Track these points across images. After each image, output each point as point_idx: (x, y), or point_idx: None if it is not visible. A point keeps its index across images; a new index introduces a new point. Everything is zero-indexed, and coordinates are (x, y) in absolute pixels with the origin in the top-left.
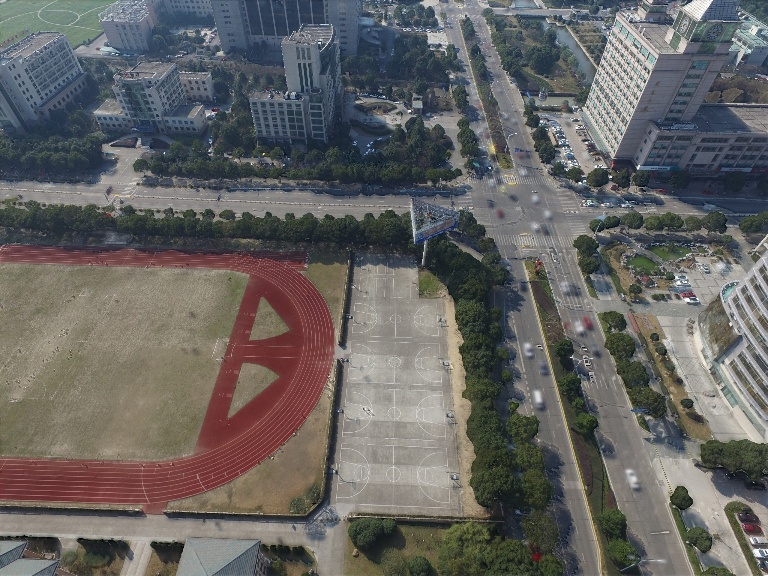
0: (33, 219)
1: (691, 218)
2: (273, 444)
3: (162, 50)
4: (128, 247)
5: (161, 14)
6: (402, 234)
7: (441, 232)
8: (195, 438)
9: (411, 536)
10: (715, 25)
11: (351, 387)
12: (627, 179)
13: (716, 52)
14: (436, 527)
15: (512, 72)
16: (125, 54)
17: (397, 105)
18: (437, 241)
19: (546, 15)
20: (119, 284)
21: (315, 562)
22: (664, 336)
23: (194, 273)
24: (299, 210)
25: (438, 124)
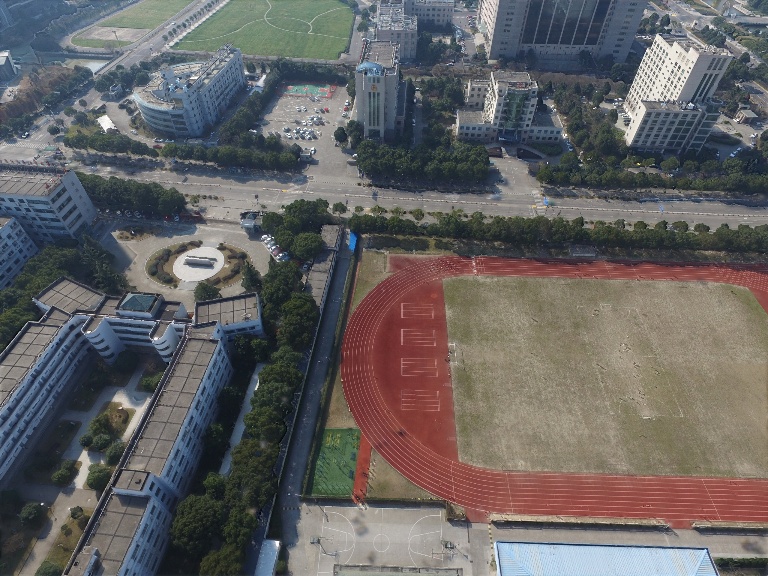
0: (507, 231)
1: None
2: None
3: (437, 58)
4: (599, 259)
5: None
6: None
7: None
8: None
9: None
10: None
11: None
12: None
13: None
14: None
15: None
16: None
17: None
18: None
19: (767, 23)
20: (629, 297)
21: None
22: None
23: (691, 286)
24: (729, 221)
25: None
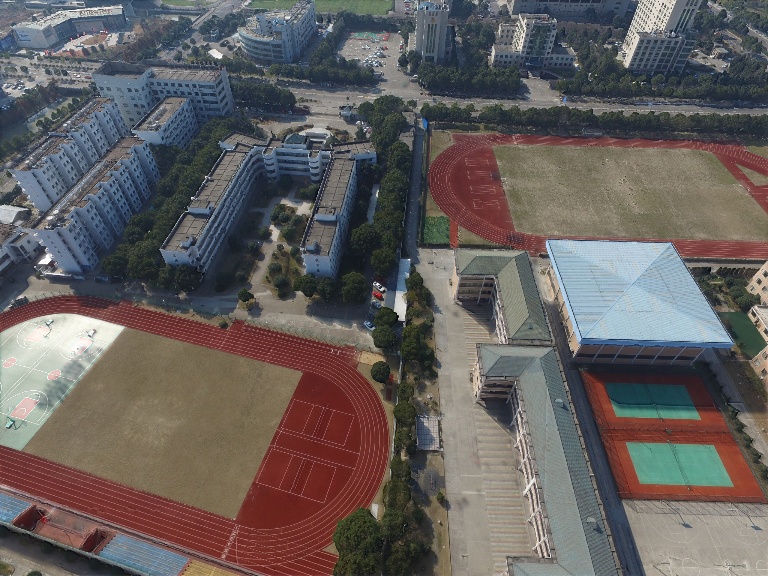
0: (538, 115)
1: None
2: None
3: None
4: (604, 136)
5: None
6: None
7: None
8: None
9: None
10: None
11: None
12: None
13: None
14: None
15: None
16: None
17: None
18: None
19: None
20: (626, 156)
21: None
22: None
23: (671, 151)
24: None
25: (762, 61)
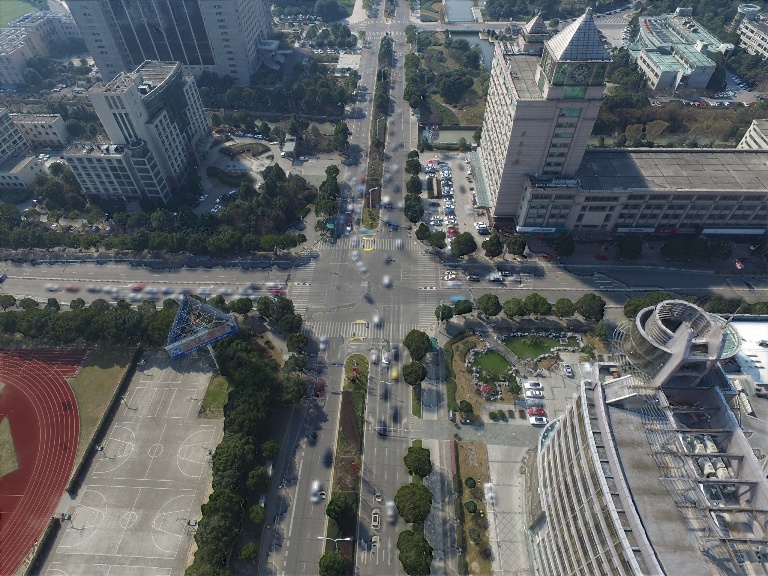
0: None
1: (561, 301)
2: None
3: (35, 84)
4: None
5: (50, 42)
6: None
7: (212, 341)
8: None
9: None
10: (579, 66)
11: (57, 561)
12: (499, 245)
13: (587, 97)
14: None
15: (410, 103)
16: None
17: (272, 146)
18: (229, 342)
19: (479, 30)
20: None
21: None
22: (488, 477)
23: None
24: (103, 290)
25: (296, 175)
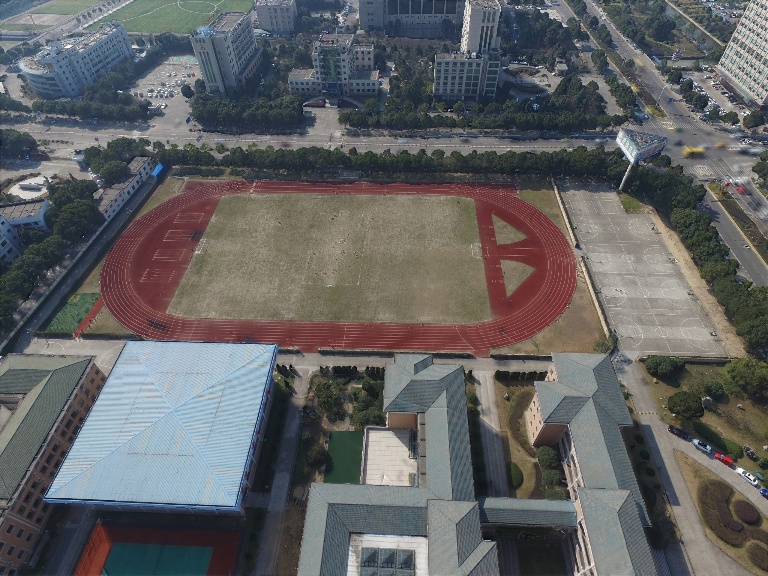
0: (282, 158)
1: None
2: (554, 313)
3: (310, 30)
4: (360, 181)
5: (295, 0)
6: (601, 163)
7: None
8: (488, 309)
9: (695, 371)
10: None
11: (599, 275)
12: None
13: None
14: (713, 365)
15: (638, 38)
16: (275, 35)
17: (539, 69)
18: (636, 167)
19: None
20: (368, 207)
21: (625, 387)
22: None
23: (426, 198)
24: None
25: None
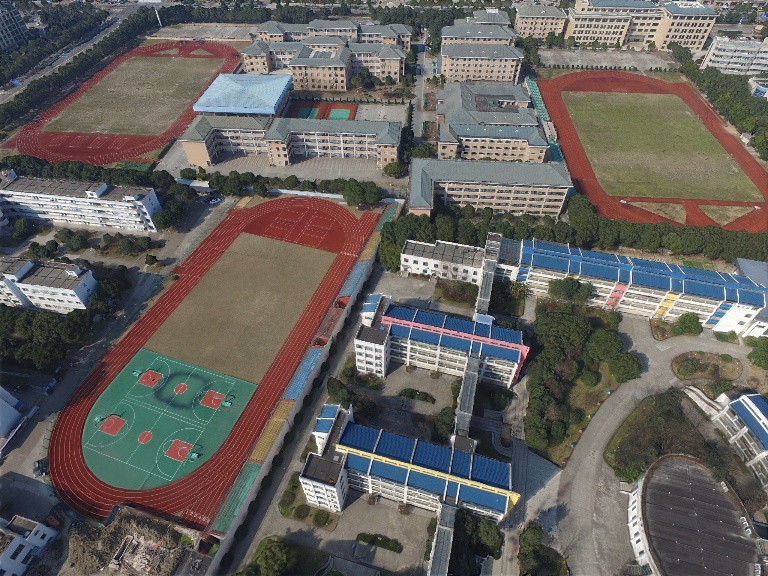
0: (29, 96)
1: None
2: None
3: None
4: None
5: None
6: None
7: None
8: None
9: None
10: None
11: None
12: None
13: None
14: None
15: None
16: None
17: None
18: None
19: None
20: (111, 82)
21: None
22: None
23: (120, 67)
24: None
25: None
